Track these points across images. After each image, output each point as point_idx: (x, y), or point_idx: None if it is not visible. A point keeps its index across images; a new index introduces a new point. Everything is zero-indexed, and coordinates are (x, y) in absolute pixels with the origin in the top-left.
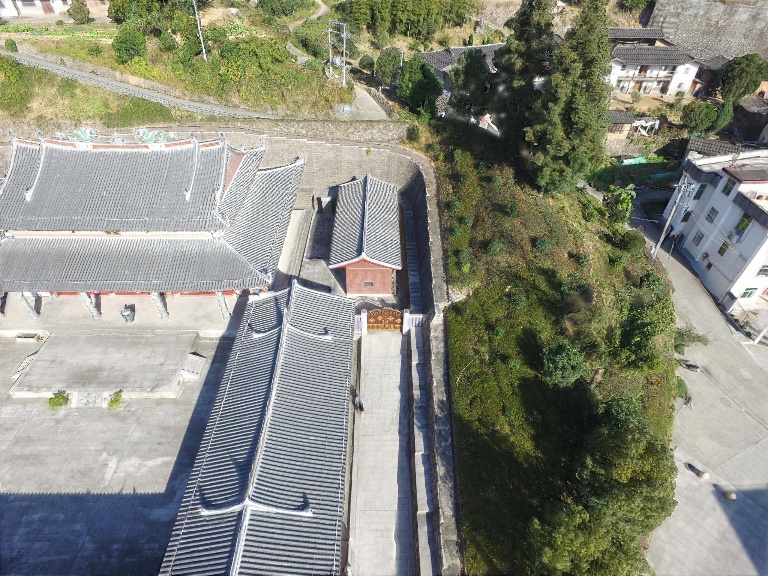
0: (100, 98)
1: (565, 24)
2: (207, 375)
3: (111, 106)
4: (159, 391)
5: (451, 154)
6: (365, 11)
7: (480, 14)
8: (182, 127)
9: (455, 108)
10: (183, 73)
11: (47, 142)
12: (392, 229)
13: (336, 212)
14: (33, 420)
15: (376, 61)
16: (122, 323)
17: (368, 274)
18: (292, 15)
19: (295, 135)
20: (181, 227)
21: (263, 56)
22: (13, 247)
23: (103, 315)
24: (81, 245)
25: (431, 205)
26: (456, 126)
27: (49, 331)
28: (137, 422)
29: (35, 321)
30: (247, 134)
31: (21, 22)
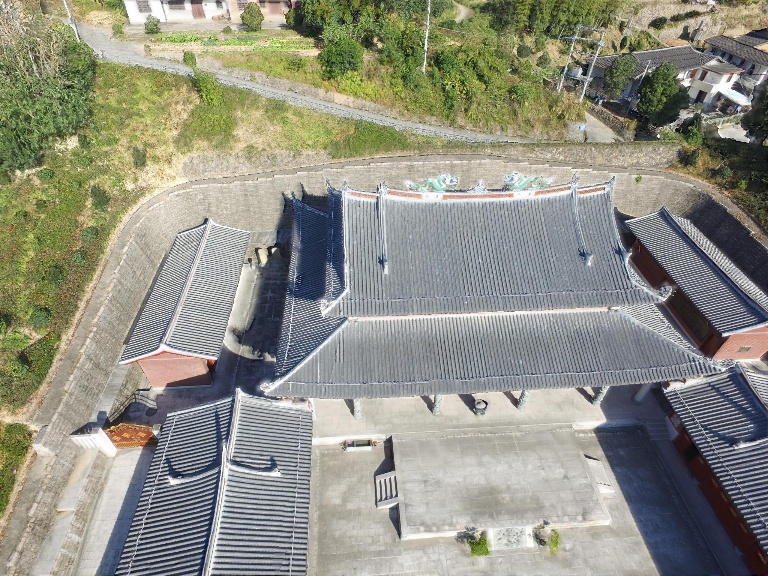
0: (319, 122)
1: (715, 24)
2: (620, 486)
3: (333, 132)
4: (594, 519)
5: (759, 182)
6: (527, 12)
7: (625, 14)
8: (426, 156)
9: (763, 128)
10: (403, 90)
11: (388, 193)
12: (744, 278)
13: (656, 257)
14: (452, 575)
15: (607, 71)
16: (472, 418)
17: (752, 339)
18: (441, 17)
19: (554, 162)
20: (599, 302)
21: (483, 67)
22: (359, 334)
23: (440, 407)
24: (445, 327)
25: (767, 245)
26: (748, 148)
27: (386, 435)
28: (588, 567)
29: (361, 421)
30: (504, 162)
31: (176, 29)
